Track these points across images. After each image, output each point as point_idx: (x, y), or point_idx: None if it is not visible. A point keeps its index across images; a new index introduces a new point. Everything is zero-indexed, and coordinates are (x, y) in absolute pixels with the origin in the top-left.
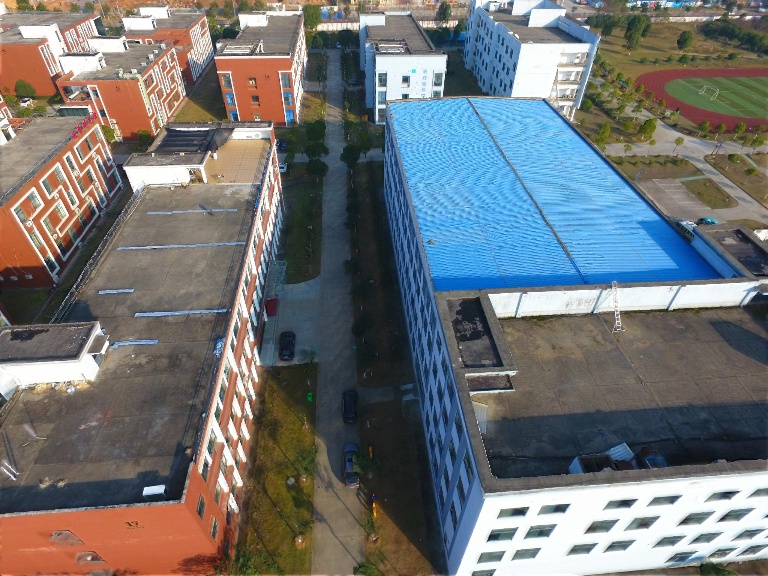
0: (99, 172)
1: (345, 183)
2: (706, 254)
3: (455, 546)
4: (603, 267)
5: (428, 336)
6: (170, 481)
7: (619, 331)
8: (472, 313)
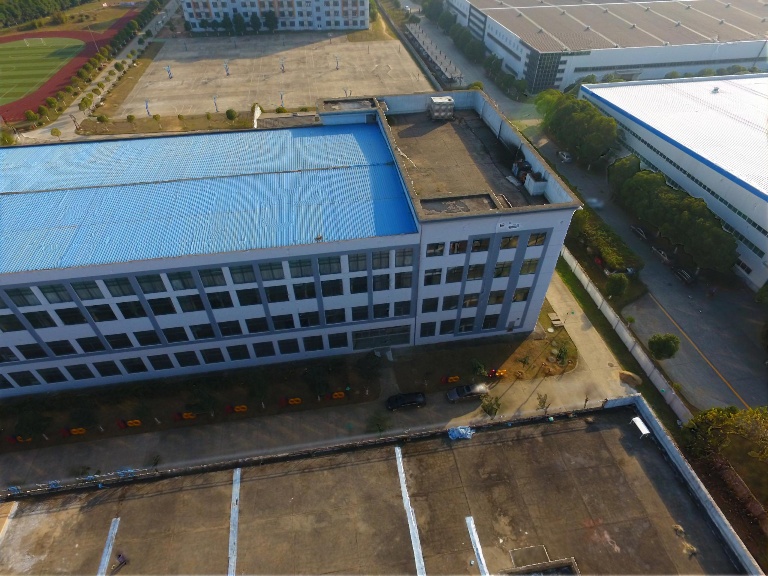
0: None
1: None
2: (340, 121)
3: (534, 301)
4: (357, 157)
5: (396, 280)
6: (622, 424)
7: (416, 166)
8: (438, 205)
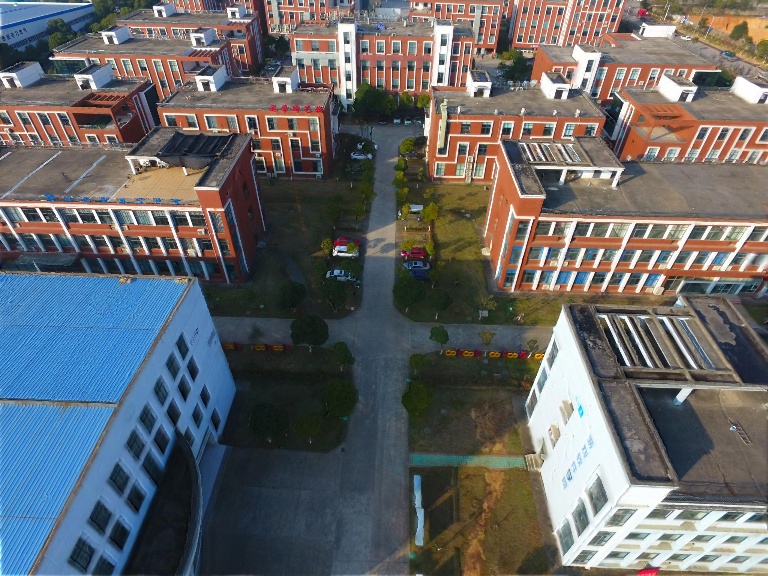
0: (291, 149)
1: (285, 343)
2: None
3: None
4: None
5: None
6: None
7: None
8: None
